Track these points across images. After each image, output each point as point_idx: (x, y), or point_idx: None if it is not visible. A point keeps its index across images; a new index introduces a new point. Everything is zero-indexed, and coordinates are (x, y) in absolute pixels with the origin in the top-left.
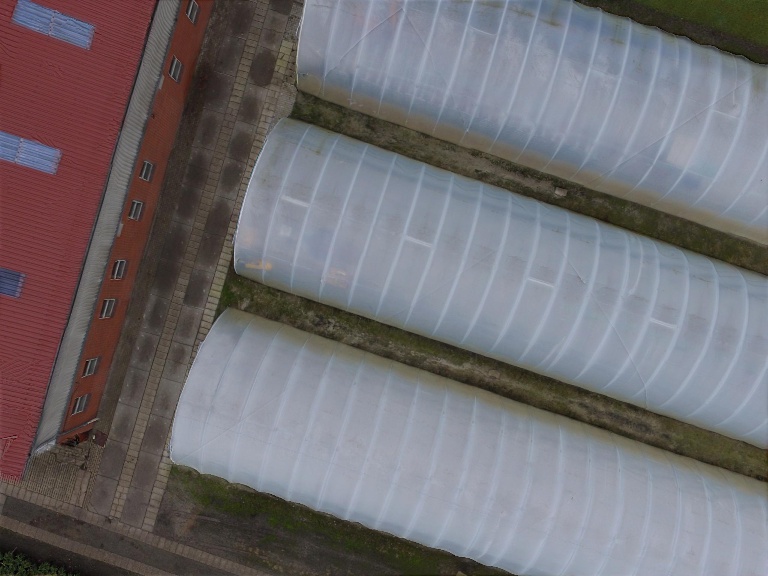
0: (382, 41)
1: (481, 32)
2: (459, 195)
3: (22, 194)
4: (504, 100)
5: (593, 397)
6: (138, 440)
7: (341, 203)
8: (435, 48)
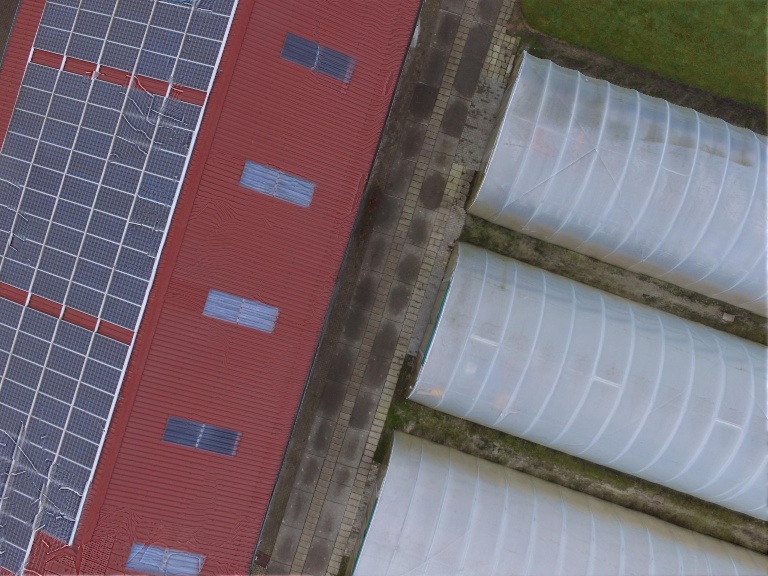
0: (572, 179)
1: (673, 172)
2: (641, 331)
3: (242, 354)
4: (691, 238)
5: (757, 523)
6: (301, 562)
7: (530, 343)
8: (625, 187)
